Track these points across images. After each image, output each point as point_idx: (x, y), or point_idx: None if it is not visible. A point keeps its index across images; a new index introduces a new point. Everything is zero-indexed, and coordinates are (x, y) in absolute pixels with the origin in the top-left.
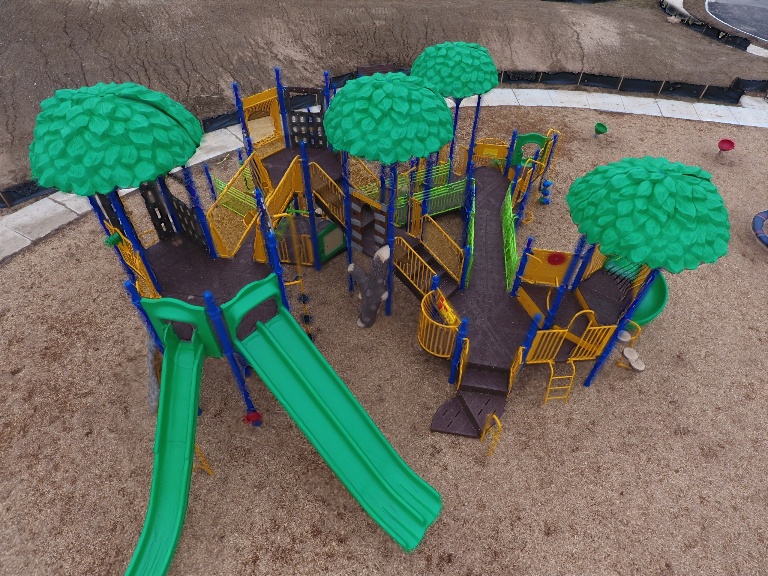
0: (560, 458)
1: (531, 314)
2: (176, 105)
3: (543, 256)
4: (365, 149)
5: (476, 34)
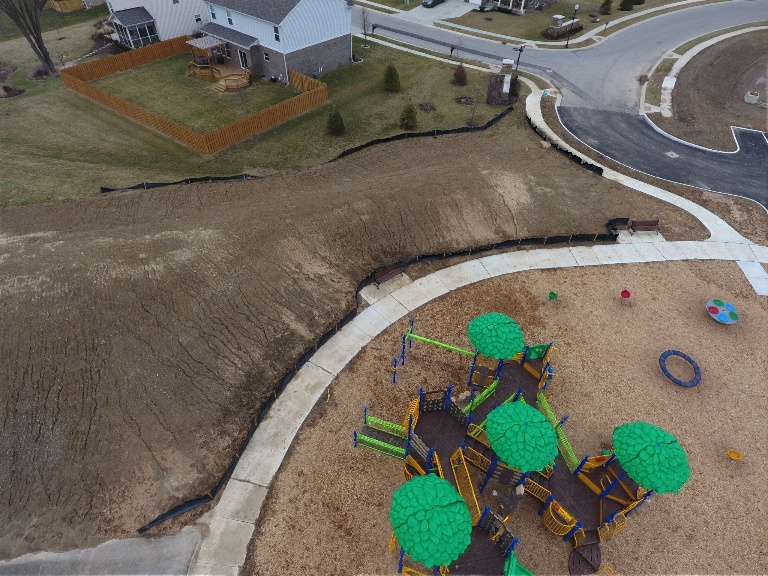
0: (632, 568)
1: (590, 487)
2: (452, 489)
3: (594, 461)
4: (529, 468)
5: (436, 213)
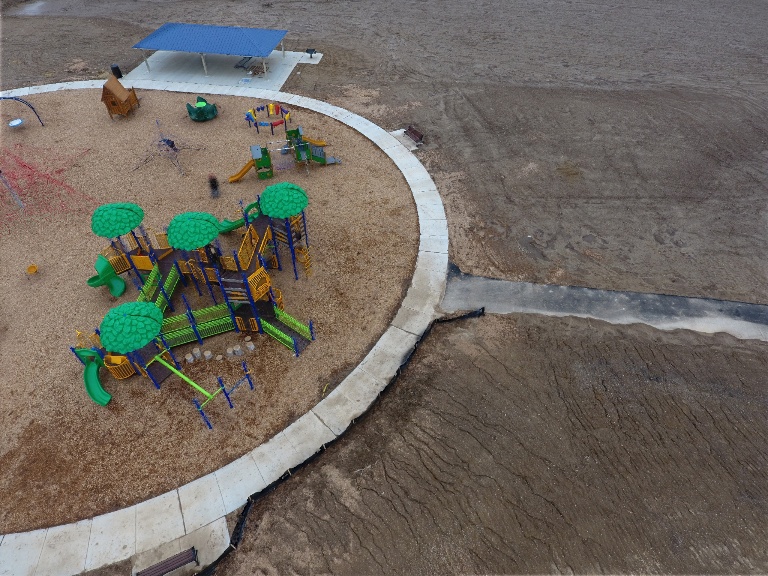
0: None
1: None
2: None
3: None
4: None
5: None
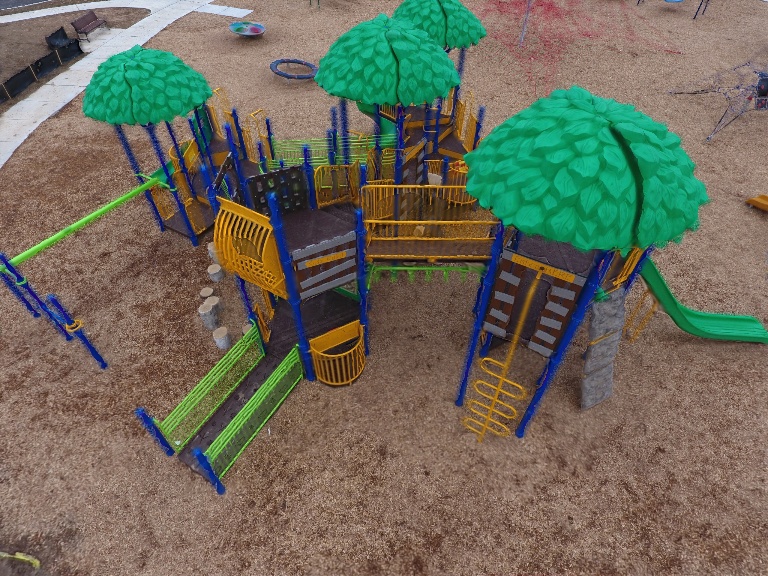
0: None
1: None
2: None
3: None
4: None
5: None
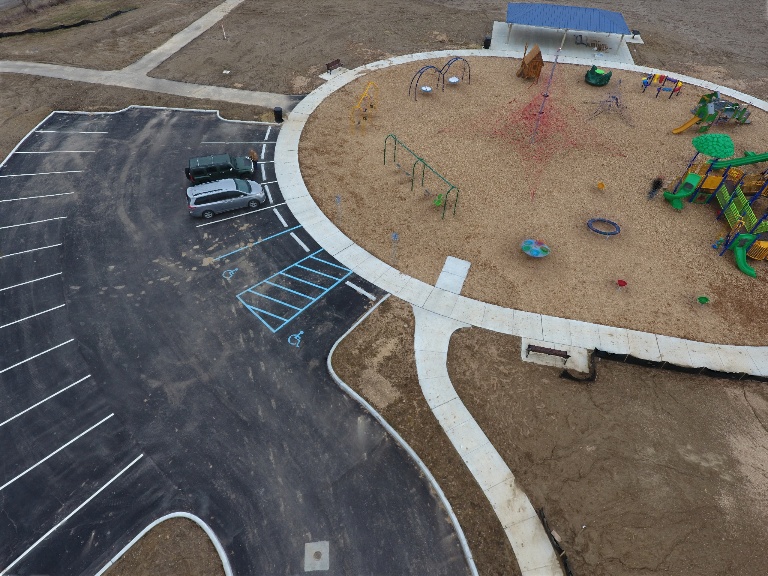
0: None
1: None
2: None
3: None
4: None
5: None
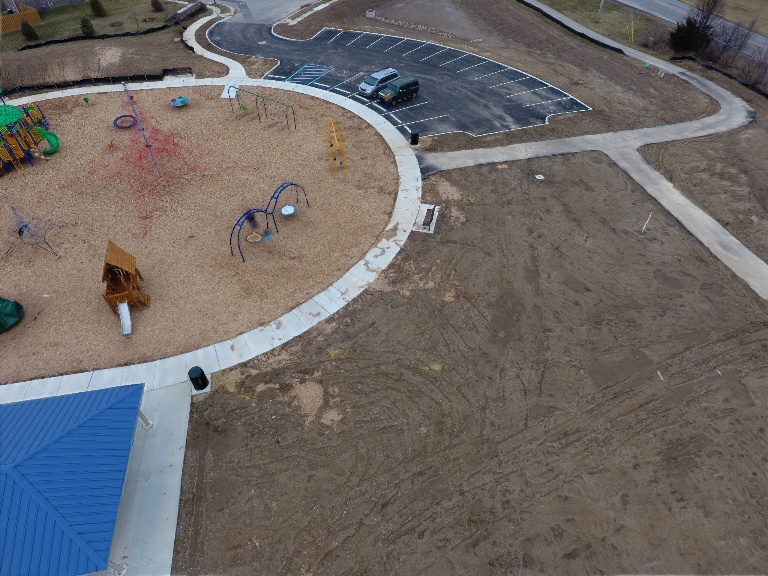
0: None
1: None
2: None
3: (6, 136)
4: None
5: (46, 67)
